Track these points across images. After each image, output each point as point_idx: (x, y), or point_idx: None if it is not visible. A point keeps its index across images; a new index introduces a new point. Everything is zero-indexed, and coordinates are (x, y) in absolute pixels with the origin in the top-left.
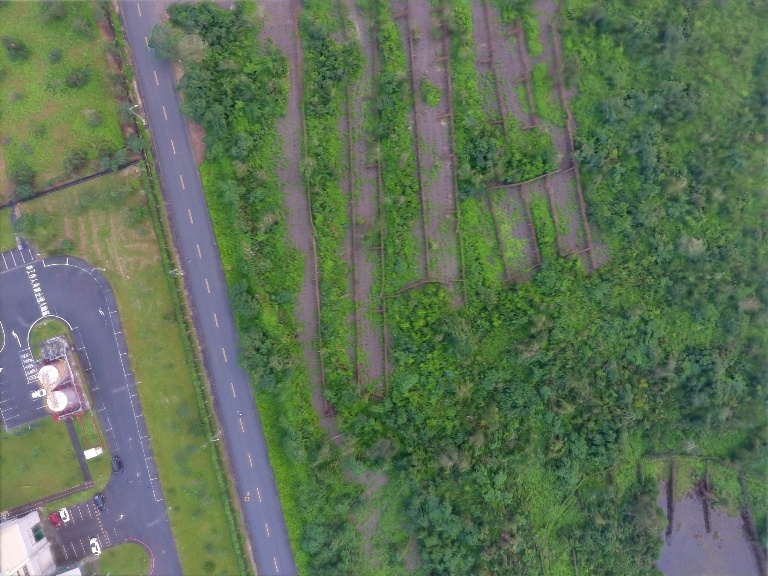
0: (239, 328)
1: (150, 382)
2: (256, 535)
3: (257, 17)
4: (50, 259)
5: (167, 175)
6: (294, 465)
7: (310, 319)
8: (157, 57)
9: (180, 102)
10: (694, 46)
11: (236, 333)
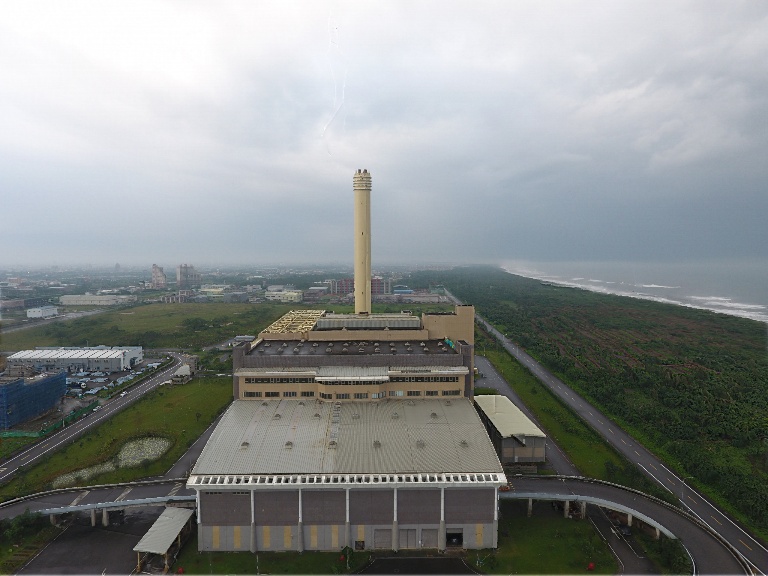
0: None
1: (502, 367)
2: (560, 393)
3: None
4: None
5: None
6: (578, 381)
7: None
8: None
9: None
10: (736, 354)
11: None
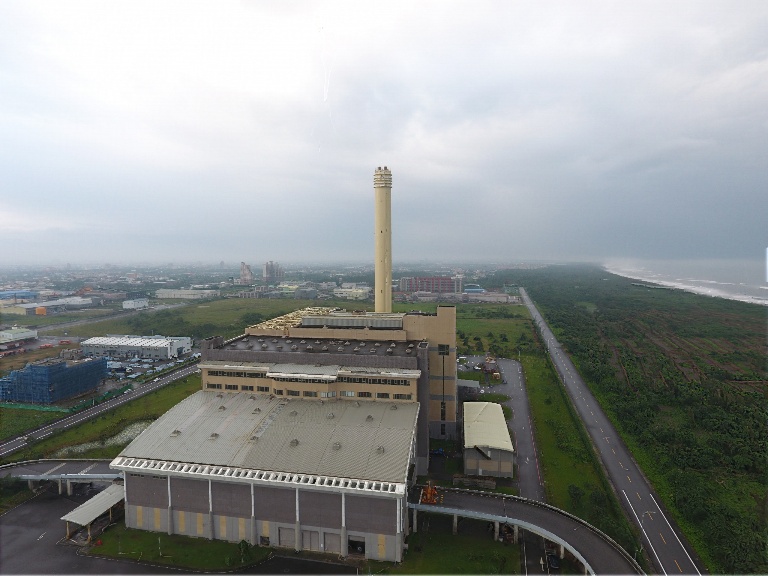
0: (581, 373)
1: None
2: None
3: (601, 346)
4: (497, 357)
5: (554, 356)
6: None
7: (621, 377)
8: (559, 342)
9: (564, 351)
10: None
11: (579, 375)
